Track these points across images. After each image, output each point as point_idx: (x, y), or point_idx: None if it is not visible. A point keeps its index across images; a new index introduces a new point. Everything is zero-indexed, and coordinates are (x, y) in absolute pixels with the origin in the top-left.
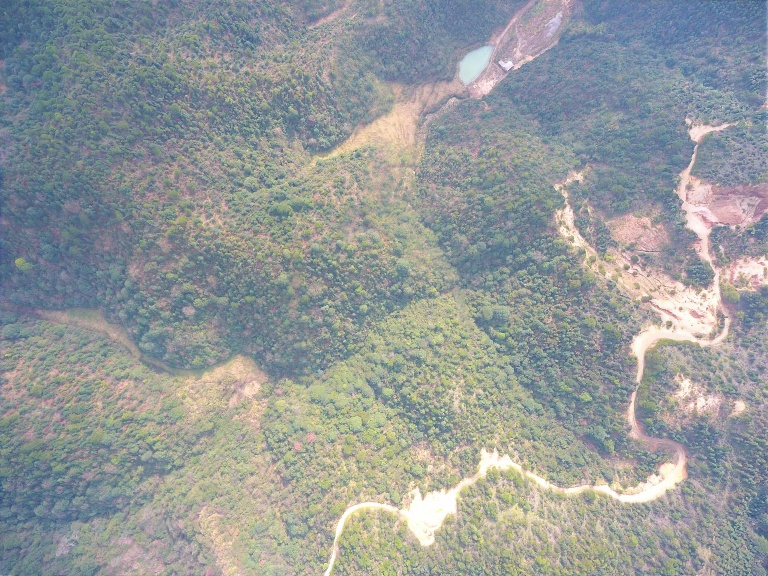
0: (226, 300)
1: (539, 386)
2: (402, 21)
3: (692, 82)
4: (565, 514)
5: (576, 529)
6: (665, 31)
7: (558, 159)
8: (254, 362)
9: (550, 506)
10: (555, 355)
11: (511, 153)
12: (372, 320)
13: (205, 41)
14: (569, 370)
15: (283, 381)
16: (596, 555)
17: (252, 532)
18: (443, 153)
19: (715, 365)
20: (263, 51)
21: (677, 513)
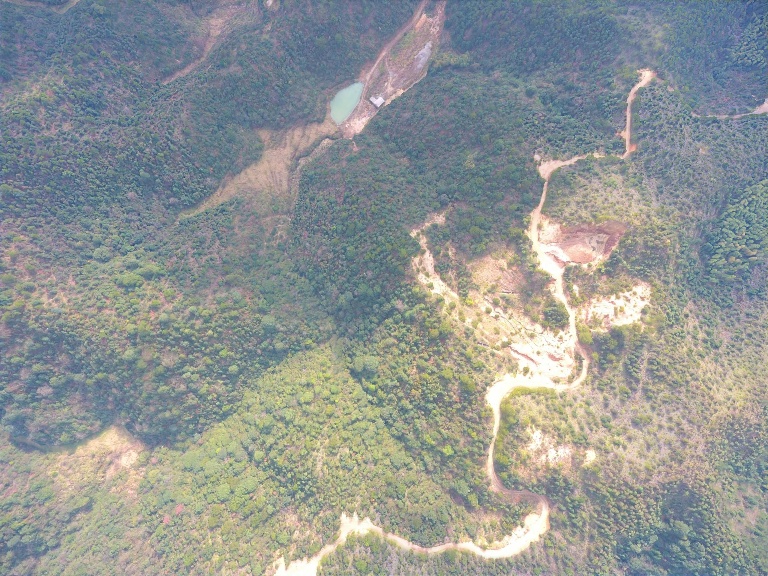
0: (82, 376)
1: (408, 439)
2: (257, 69)
3: (550, 112)
4: None
5: None
6: (526, 58)
7: (418, 202)
8: (128, 431)
9: (409, 570)
10: (421, 407)
11: (370, 199)
12: (248, 378)
13: (39, 114)
14: (433, 422)
15: (158, 449)
16: None
17: None
18: (313, 199)
19: (569, 412)
20: (109, 115)
21: (538, 568)
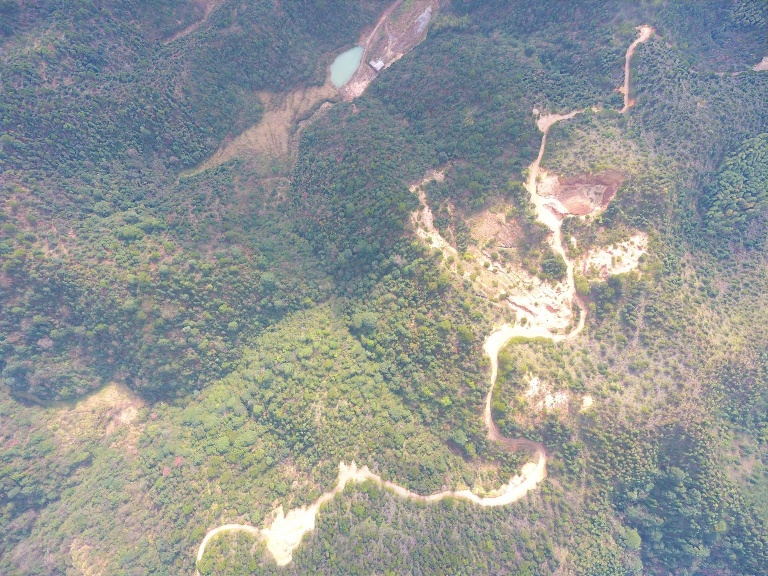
0: (83, 329)
1: (406, 392)
2: (257, 30)
3: (549, 70)
4: (423, 523)
5: (431, 538)
6: (525, 19)
7: (418, 159)
8: (128, 388)
9: (406, 516)
10: (419, 360)
11: (370, 157)
12: (247, 336)
13: (41, 68)
14: (431, 374)
15: (158, 405)
16: (449, 563)
17: (121, 562)
18: (313, 160)
19: (566, 360)
20: (110, 72)
21: (535, 514)
